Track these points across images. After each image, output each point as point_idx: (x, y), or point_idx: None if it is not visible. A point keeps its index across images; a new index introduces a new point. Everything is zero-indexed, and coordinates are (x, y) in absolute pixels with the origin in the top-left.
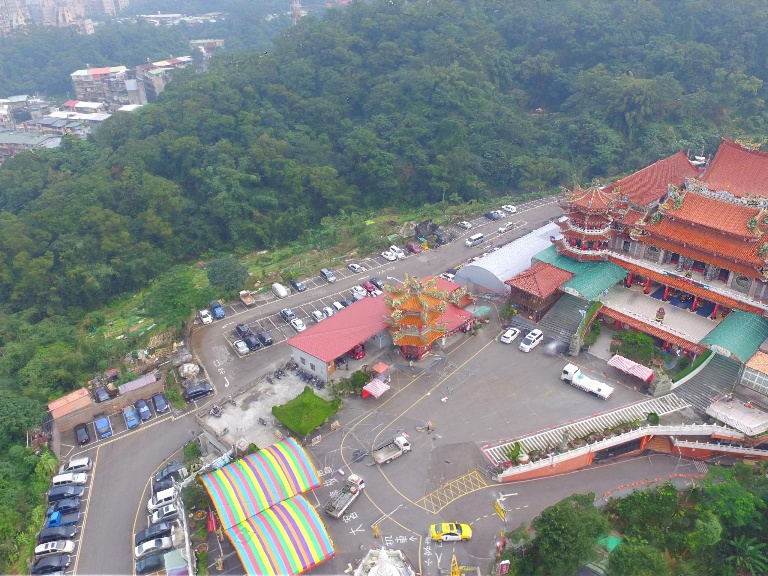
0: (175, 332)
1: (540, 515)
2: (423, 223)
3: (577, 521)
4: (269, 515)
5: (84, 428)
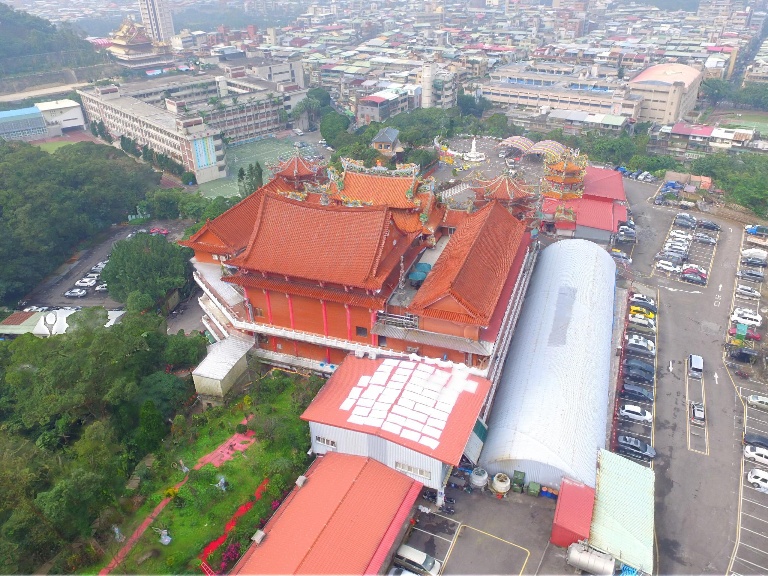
0: (741, 210)
1: (430, 153)
2: None
3: None
4: (524, 143)
5: (677, 182)
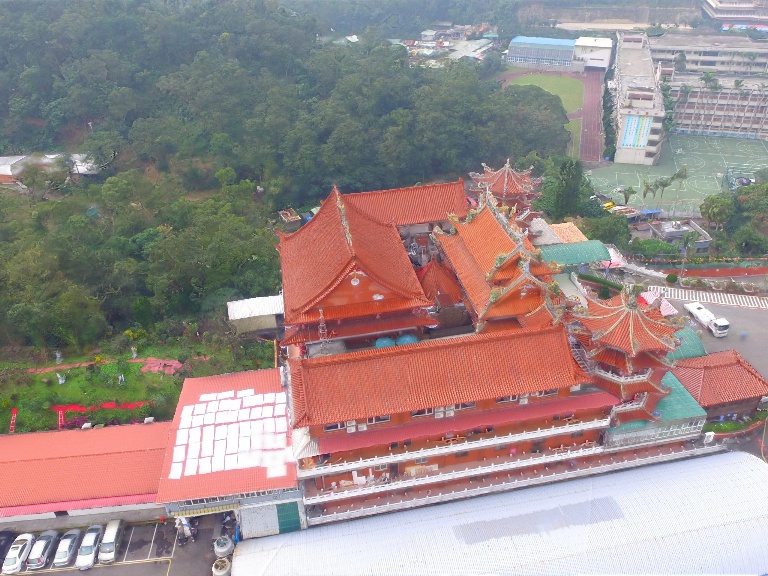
0: None
1: None
2: None
3: None
4: None
5: None
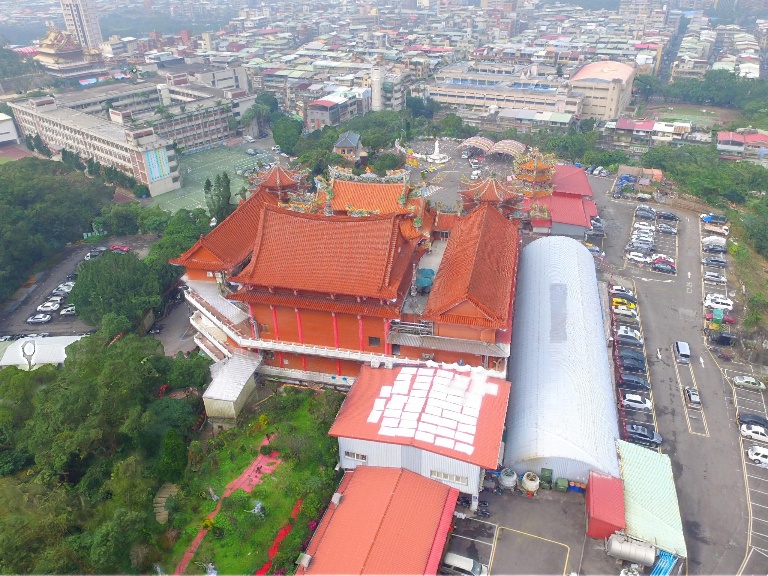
0: None
1: None
2: (767, 334)
3: (383, 158)
4: (485, 143)
5: None
